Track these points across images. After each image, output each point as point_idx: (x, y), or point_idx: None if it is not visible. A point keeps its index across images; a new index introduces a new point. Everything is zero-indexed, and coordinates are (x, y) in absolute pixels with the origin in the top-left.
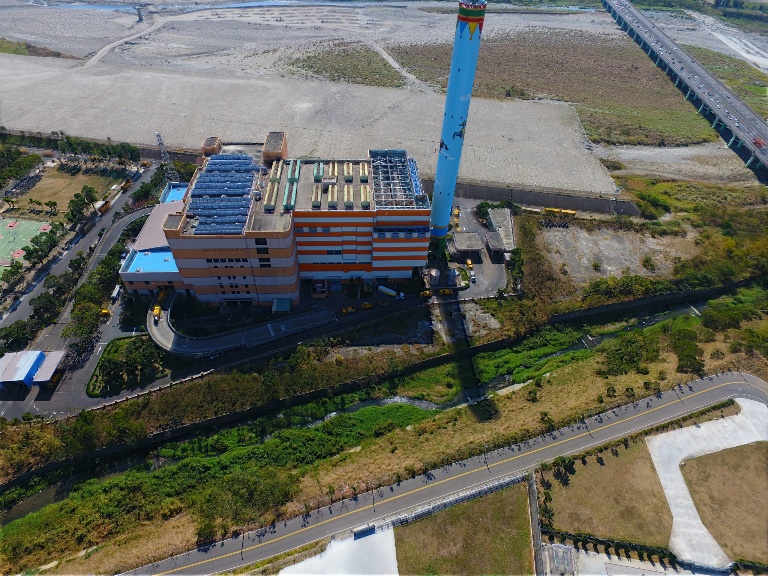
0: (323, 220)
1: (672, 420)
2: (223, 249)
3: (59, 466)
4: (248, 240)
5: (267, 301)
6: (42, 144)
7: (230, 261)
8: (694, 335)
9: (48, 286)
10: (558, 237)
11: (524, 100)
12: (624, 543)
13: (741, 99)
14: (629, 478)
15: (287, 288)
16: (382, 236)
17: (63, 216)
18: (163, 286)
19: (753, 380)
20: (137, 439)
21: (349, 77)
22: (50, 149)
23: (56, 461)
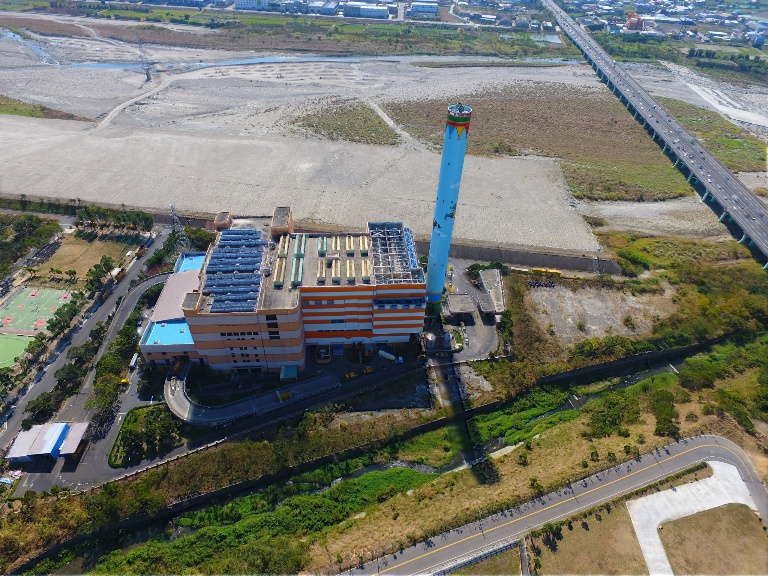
0: (327, 294)
1: (650, 484)
2: (236, 324)
3: (85, 538)
4: (259, 316)
5: (275, 368)
6: (60, 210)
7: (242, 334)
8: (671, 397)
9: (71, 357)
10: (545, 297)
11: (511, 156)
12: None
13: (714, 152)
14: (611, 543)
15: (294, 356)
16: (382, 308)
17: (82, 284)
18: (179, 356)
19: (724, 442)
20: (158, 510)
21: (347, 135)
22: (67, 215)
23: (83, 533)
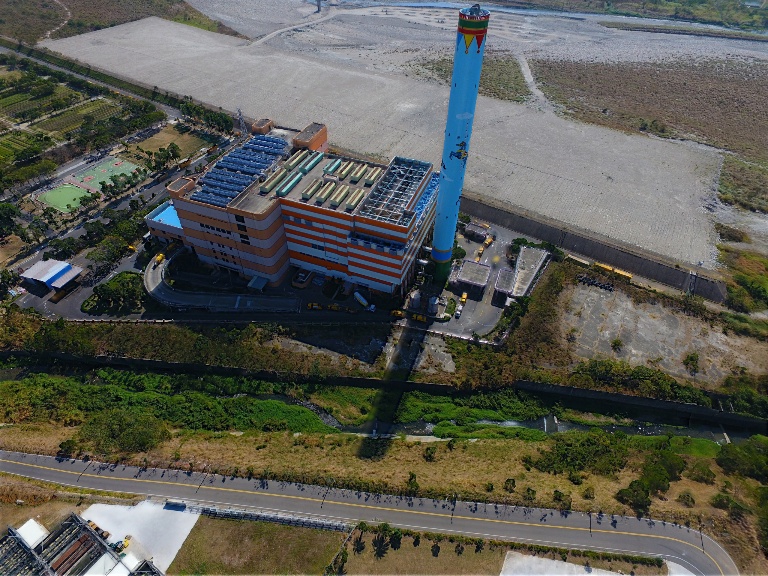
0: (306, 213)
1: (558, 547)
2: (212, 218)
3: (31, 355)
4: (230, 215)
5: (250, 276)
6: (176, 105)
7: (218, 230)
8: (677, 464)
9: (104, 216)
10: (591, 298)
11: (660, 138)
12: None
13: None
14: None
15: (265, 269)
16: (354, 242)
17: (154, 165)
18: (175, 239)
19: (714, 550)
20: (83, 354)
21: None
22: None
23: None
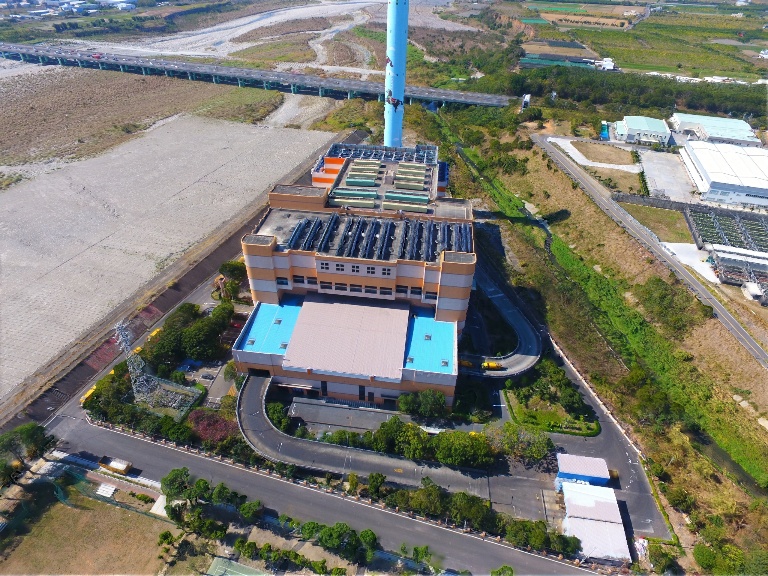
0: None
1: (567, 156)
2: None
3: None
4: None
5: None
6: None
7: None
8: None
9: None
10: None
11: (147, 129)
12: (641, 180)
13: None
14: None
15: None
16: None
17: (180, 572)
18: None
19: (535, 135)
20: None
21: None
22: None
23: None
